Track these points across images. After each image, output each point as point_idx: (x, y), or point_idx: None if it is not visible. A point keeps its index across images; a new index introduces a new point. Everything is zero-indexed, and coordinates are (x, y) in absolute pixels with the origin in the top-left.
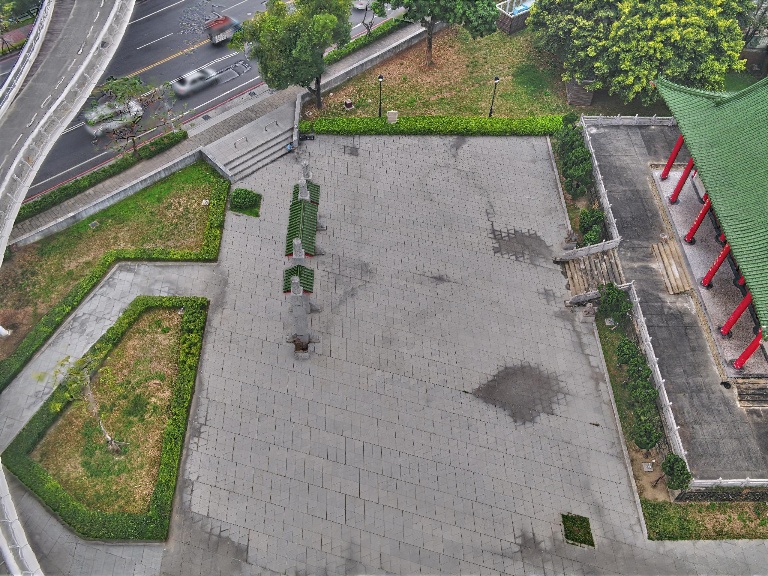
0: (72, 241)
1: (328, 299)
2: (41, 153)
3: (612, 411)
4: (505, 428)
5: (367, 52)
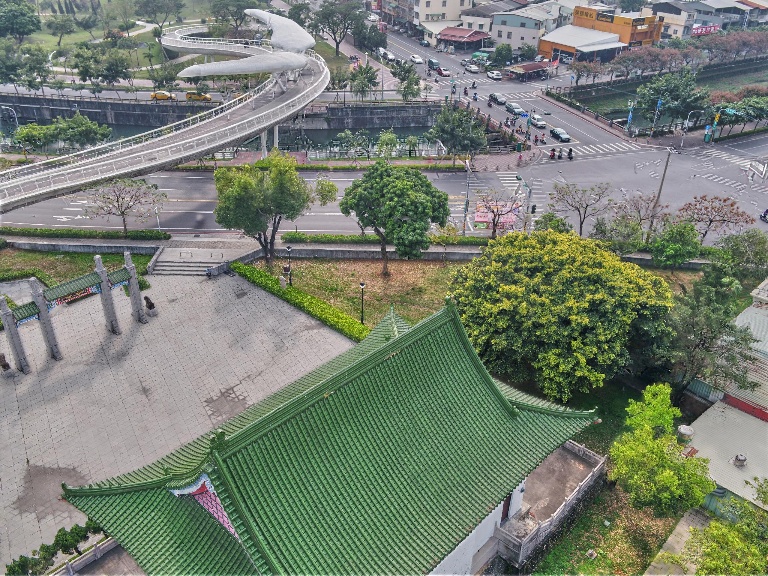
0: (38, 257)
1: (73, 357)
2: (40, 190)
3: (70, 555)
4: (2, 501)
5: (351, 247)
